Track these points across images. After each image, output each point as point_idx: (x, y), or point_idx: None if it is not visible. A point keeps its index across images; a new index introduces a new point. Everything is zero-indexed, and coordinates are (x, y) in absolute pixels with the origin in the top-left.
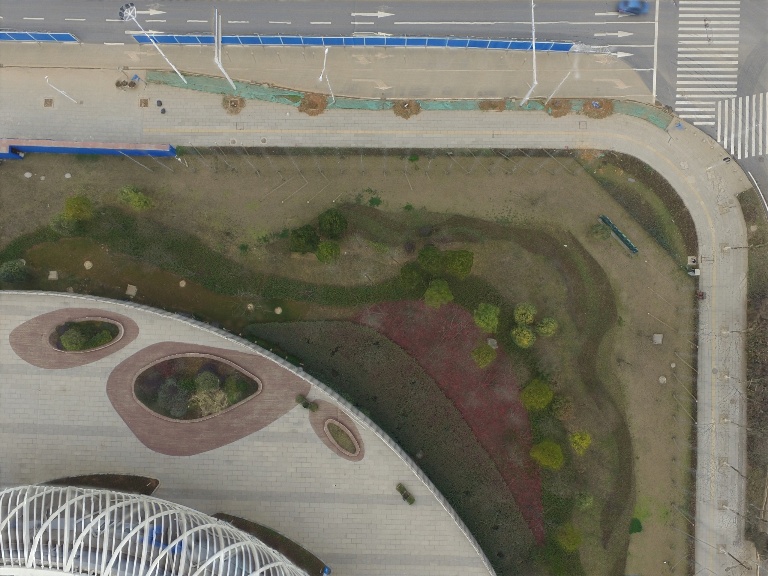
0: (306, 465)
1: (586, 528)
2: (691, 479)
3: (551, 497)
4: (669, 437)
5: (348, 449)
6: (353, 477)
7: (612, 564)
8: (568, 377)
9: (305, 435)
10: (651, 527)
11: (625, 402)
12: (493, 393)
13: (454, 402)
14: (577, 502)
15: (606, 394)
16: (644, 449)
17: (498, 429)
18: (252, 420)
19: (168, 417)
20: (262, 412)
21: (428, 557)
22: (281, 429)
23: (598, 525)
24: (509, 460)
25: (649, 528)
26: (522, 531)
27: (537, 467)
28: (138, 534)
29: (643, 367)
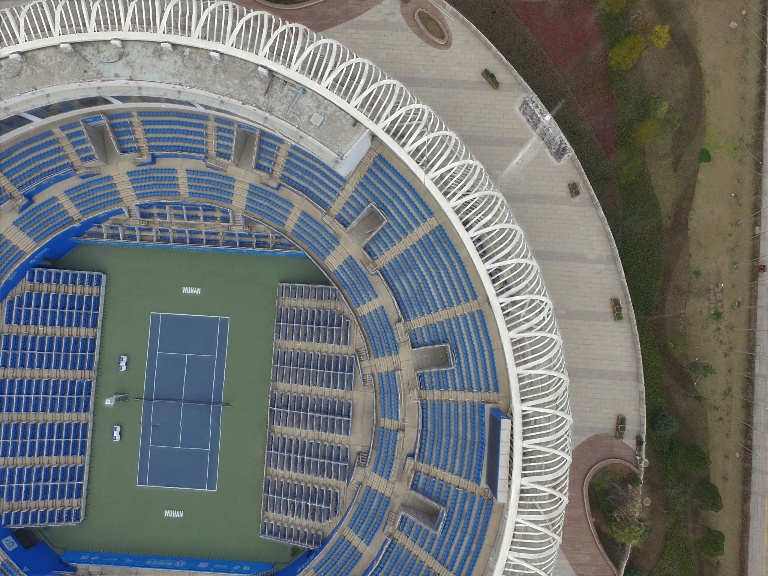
0: (397, 52)
1: (657, 151)
2: (759, 119)
3: (625, 118)
4: (739, 77)
5: (437, 36)
6: (441, 64)
7: (682, 188)
8: (643, 7)
9: (396, 24)
10: (720, 159)
11: (697, 39)
12: (570, 21)
13: (532, 31)
14: (652, 111)
15: (679, 27)
16: (715, 85)
17: (574, 55)
18: (347, 10)
19: (269, 2)
20: (356, 2)
21: (511, 139)
22: (374, 18)
23: (669, 149)
24: (584, 86)
25: (718, 160)
26: (595, 151)
27: (611, 90)
28: (259, 15)
29: (715, 8)
